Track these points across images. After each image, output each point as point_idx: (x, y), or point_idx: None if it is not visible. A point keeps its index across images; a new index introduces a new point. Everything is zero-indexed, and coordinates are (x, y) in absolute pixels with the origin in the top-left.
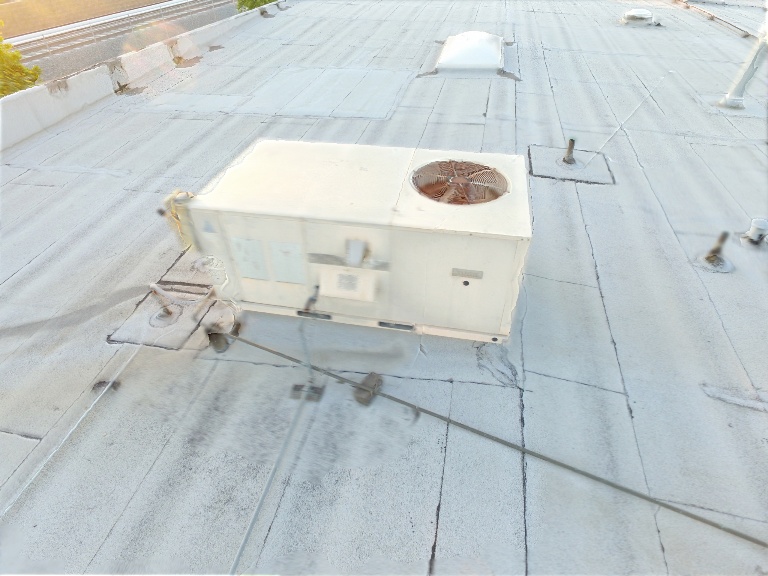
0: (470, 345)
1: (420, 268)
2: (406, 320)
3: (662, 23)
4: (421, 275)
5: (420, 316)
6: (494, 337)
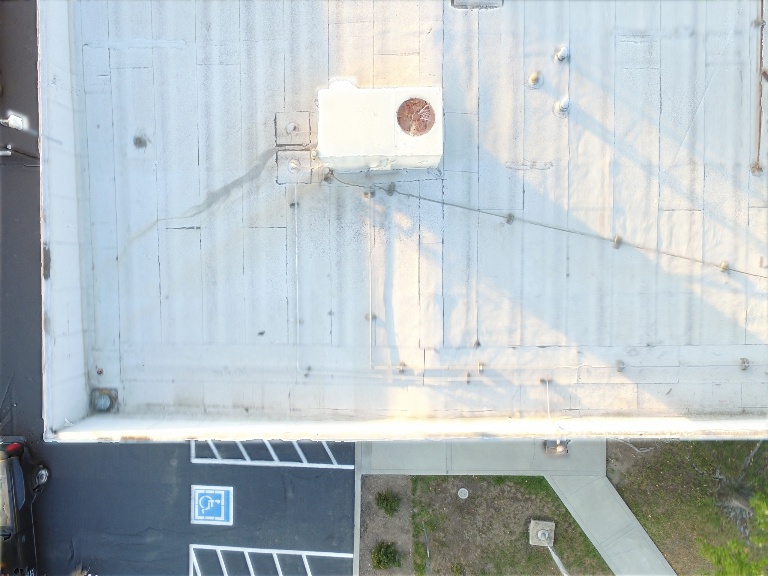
0: None
1: None
2: None
3: None
4: None
5: None
6: None
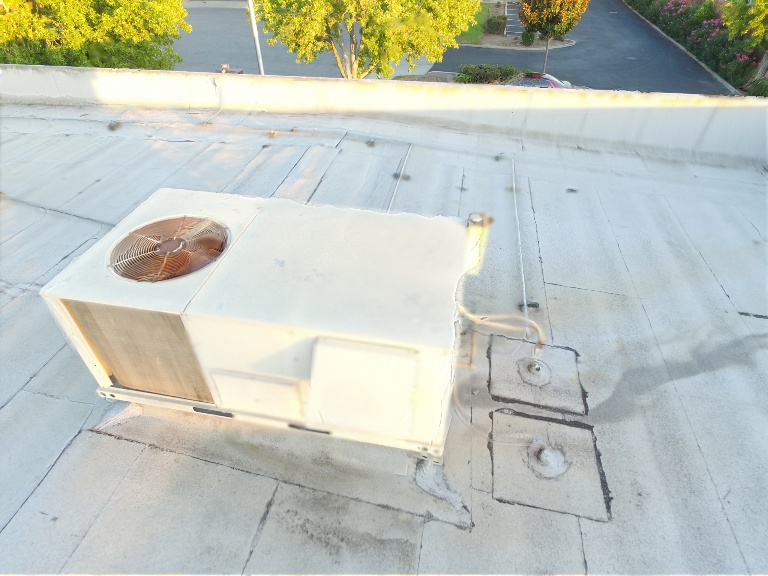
0: None
1: None
2: None
3: None
4: None
5: None
6: None
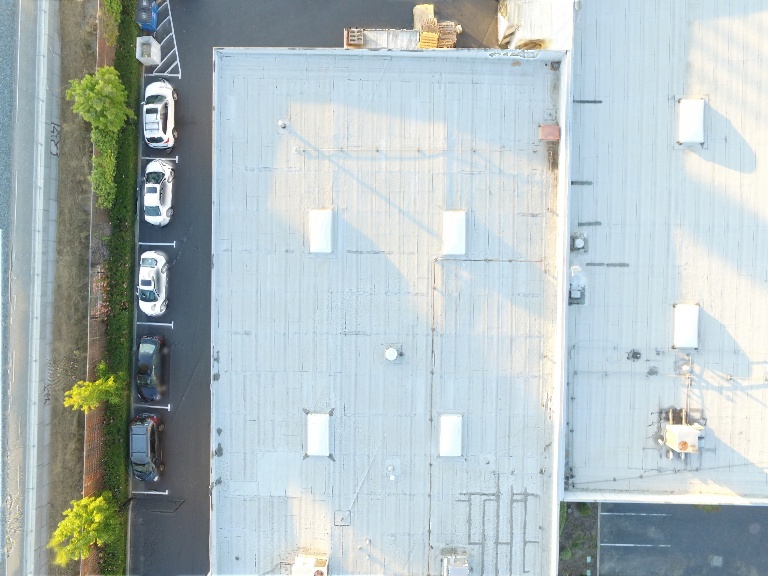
0: None
1: None
2: None
3: (405, 346)
4: None
5: None
6: None
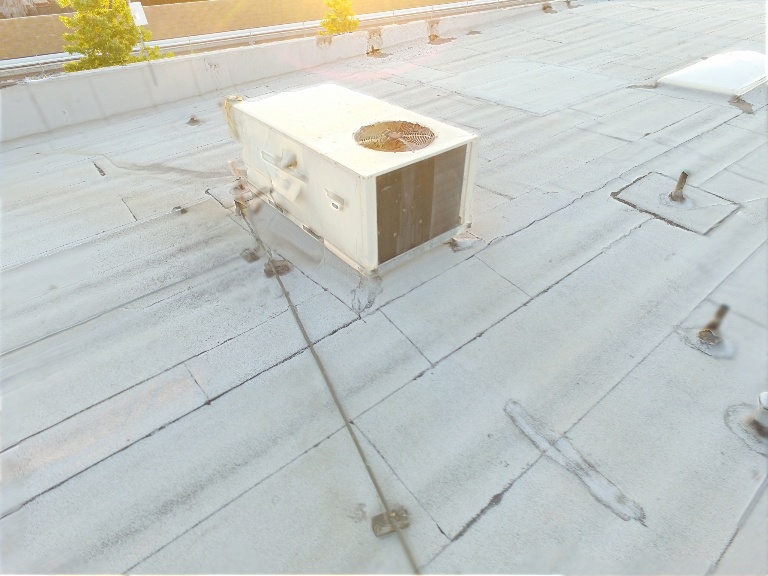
0: (350, 269)
1: (314, 184)
2: (316, 230)
3: None
4: (315, 190)
5: (322, 229)
6: (358, 266)
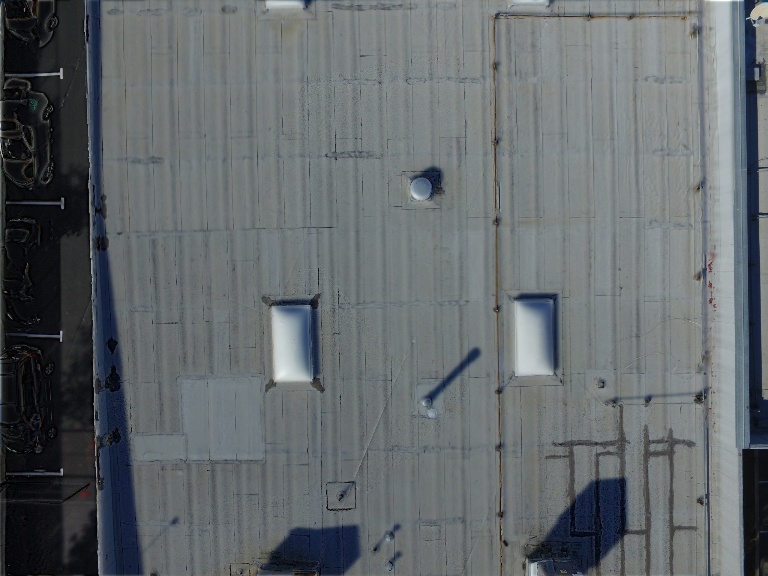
0: None
1: None
2: None
3: (445, 176)
4: None
5: None
6: None
